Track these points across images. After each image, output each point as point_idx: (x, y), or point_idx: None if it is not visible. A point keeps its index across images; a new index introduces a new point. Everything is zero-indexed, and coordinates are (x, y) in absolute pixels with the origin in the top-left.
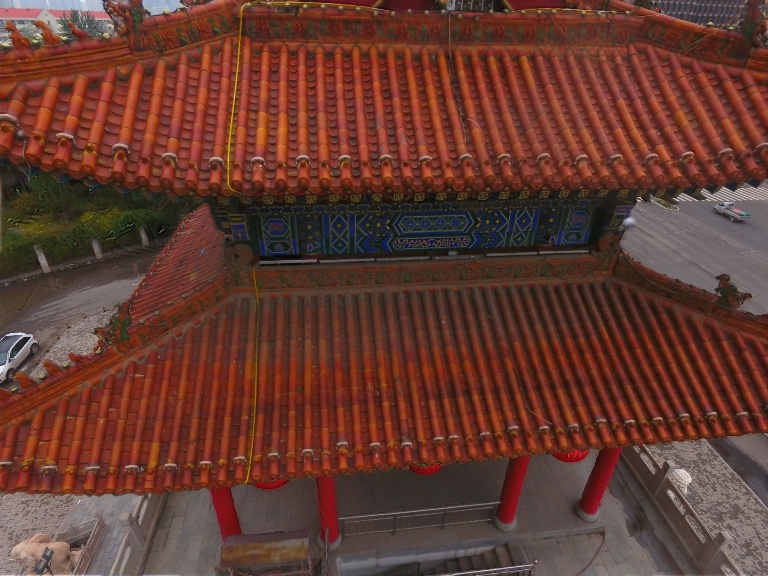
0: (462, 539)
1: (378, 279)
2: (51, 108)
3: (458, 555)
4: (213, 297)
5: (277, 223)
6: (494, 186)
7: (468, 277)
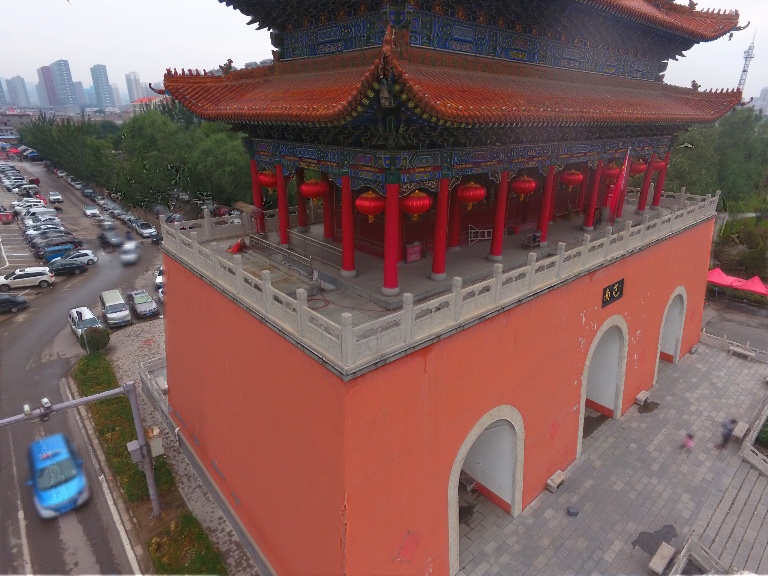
0: (322, 269)
1: (308, 68)
2: None
3: (322, 286)
4: (263, 73)
5: (287, 40)
6: None
7: (336, 66)
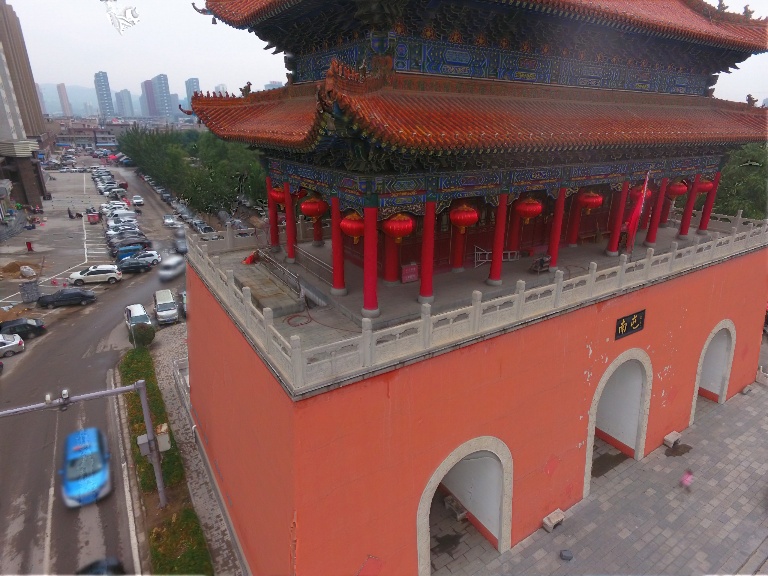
0: (317, 285)
1: None
2: (232, 6)
3: None
4: (278, 96)
5: None
6: (271, 7)
7: None
